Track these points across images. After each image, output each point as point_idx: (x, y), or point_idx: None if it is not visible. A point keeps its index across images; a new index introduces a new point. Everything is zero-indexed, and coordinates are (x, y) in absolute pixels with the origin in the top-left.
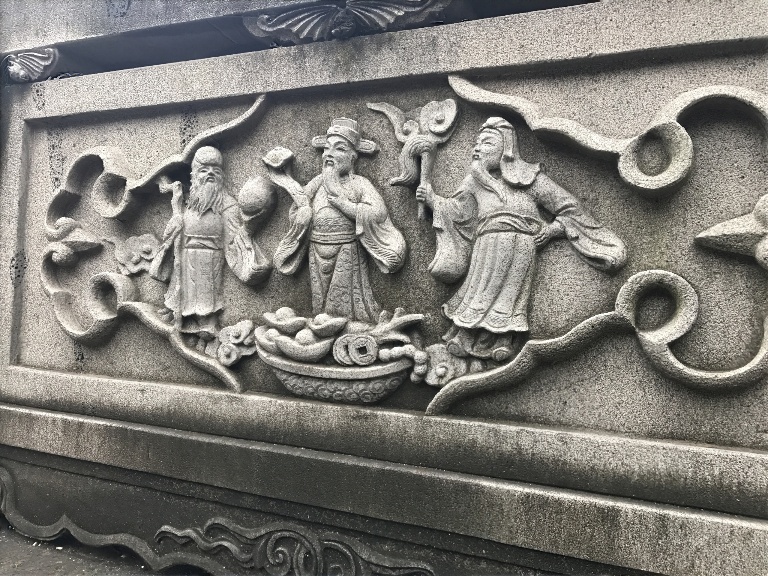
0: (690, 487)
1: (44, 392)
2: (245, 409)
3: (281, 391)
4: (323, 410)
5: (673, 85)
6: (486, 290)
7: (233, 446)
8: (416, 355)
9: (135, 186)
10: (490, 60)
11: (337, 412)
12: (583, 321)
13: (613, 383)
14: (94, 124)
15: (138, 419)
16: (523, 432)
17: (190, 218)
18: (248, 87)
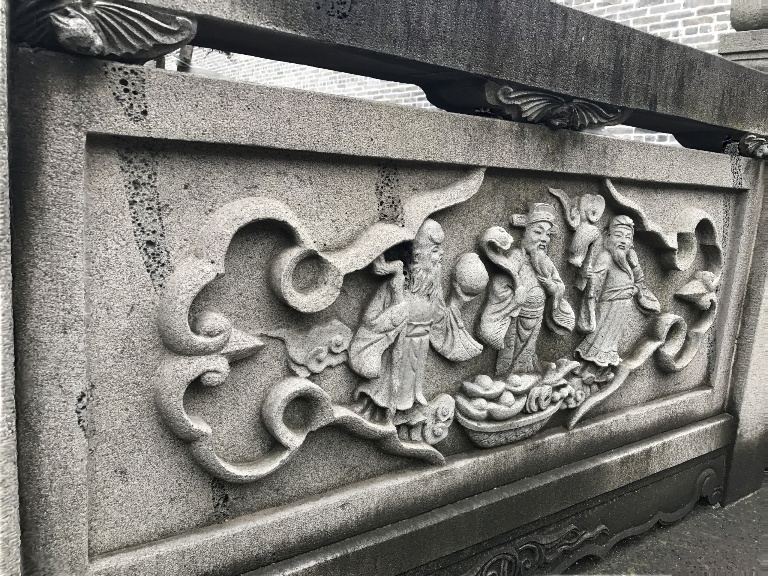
0: (663, 423)
1: (181, 573)
2: (454, 477)
3: (466, 448)
4: (512, 452)
5: (681, 203)
6: (612, 338)
7: (461, 514)
8: (573, 391)
9: (354, 269)
10: (630, 173)
11: (521, 450)
12: (647, 349)
13: (640, 378)
14: (228, 156)
15: (340, 537)
16: (614, 422)
17: (418, 304)
18: (474, 157)
